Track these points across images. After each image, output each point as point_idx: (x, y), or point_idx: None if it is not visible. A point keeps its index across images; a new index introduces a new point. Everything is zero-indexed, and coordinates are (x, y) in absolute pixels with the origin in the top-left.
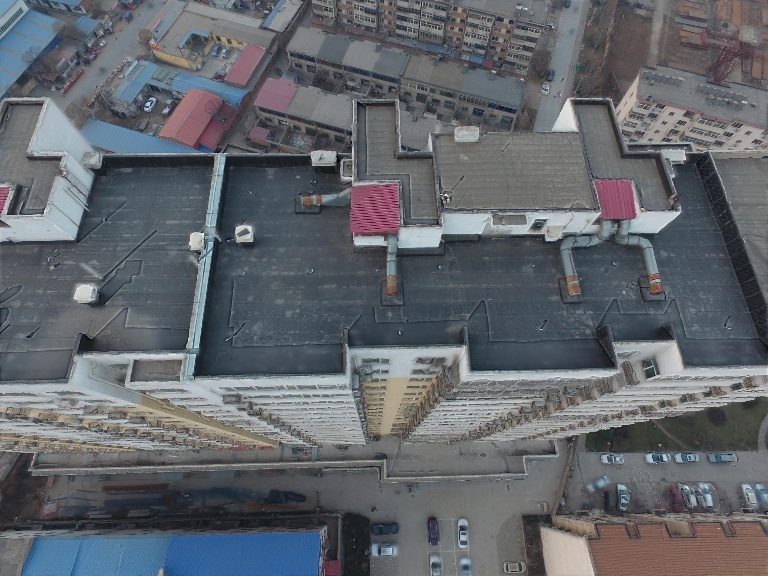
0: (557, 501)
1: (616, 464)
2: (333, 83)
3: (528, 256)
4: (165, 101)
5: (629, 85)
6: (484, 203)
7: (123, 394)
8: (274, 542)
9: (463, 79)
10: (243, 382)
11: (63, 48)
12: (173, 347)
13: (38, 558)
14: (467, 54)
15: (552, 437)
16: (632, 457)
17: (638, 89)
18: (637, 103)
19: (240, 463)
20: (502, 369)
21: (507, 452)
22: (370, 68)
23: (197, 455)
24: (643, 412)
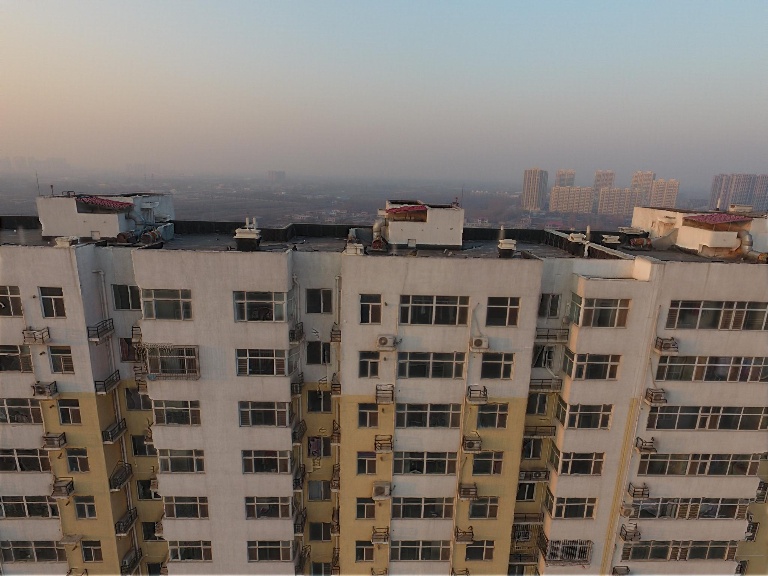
0: None
1: None
2: None
3: None
4: None
5: None
6: None
7: None
8: None
9: None
10: (708, 276)
11: None
12: None
13: None
14: None
15: None
16: None
17: None
18: None
19: None
20: None
21: None
22: None
23: None
24: None
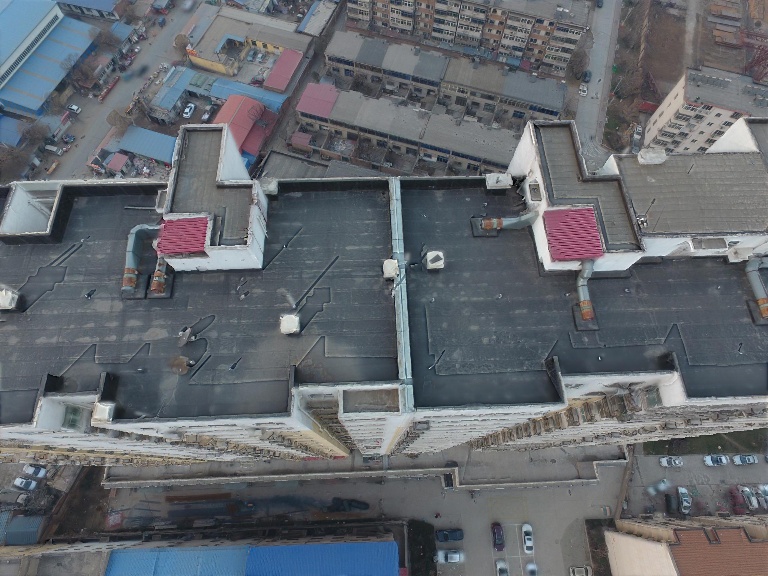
0: (619, 505)
1: (675, 467)
2: (371, 87)
3: (712, 278)
4: (203, 107)
5: (666, 85)
6: (680, 227)
7: (307, 421)
8: (352, 552)
9: (504, 82)
10: (459, 412)
11: (99, 55)
12: (378, 376)
13: (116, 571)
14: (504, 56)
15: (624, 443)
16: (690, 460)
17: (685, 91)
18: (684, 105)
19: (313, 473)
20: (708, 394)
21: (577, 458)
22: (410, 72)
23: (268, 465)
24: (761, 423)
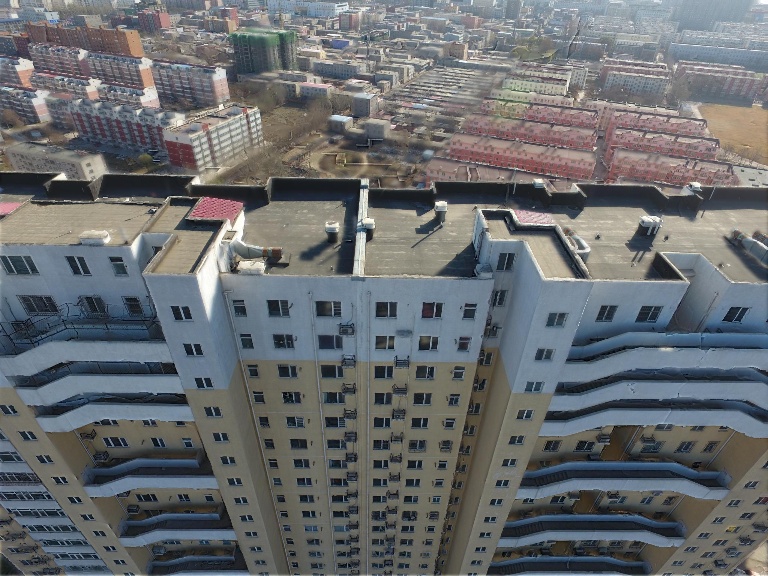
0: None
1: None
2: None
3: None
4: None
5: None
6: None
7: None
8: None
9: None
10: None
11: None
12: (381, 202)
13: None
14: None
15: None
16: None
17: None
18: None
19: None
20: (174, 189)
21: None
22: None
23: None
24: None
